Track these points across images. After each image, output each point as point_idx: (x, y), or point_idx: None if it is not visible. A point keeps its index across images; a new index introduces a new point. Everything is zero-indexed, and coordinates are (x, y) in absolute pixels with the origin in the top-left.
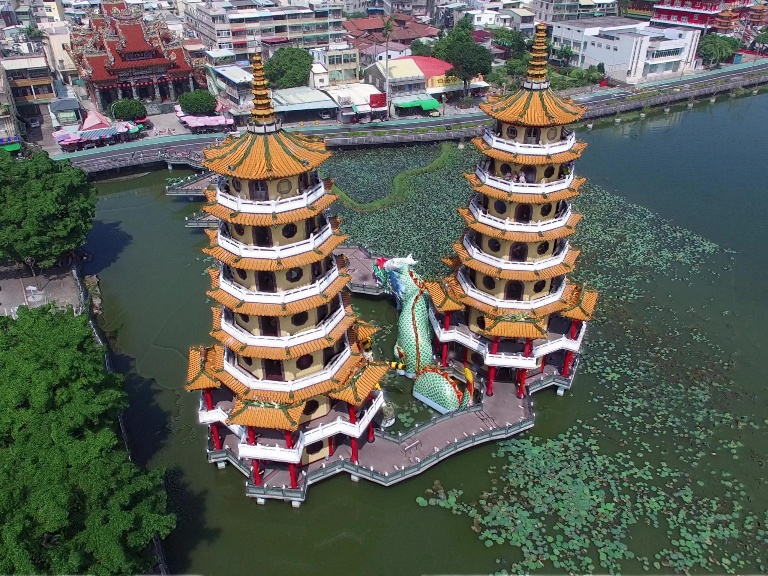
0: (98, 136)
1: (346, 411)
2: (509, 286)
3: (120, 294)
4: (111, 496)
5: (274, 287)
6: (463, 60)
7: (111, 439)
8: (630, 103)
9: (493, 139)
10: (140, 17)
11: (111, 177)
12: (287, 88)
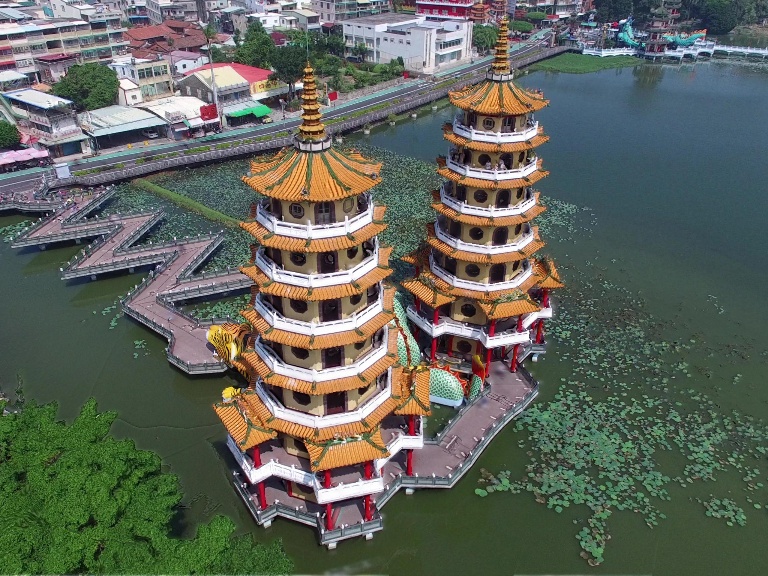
0: None
1: (395, 426)
2: None
3: (9, 374)
4: None
5: (339, 314)
6: (286, 63)
7: (229, 526)
8: (438, 91)
9: (472, 132)
10: None
11: None
12: (96, 109)
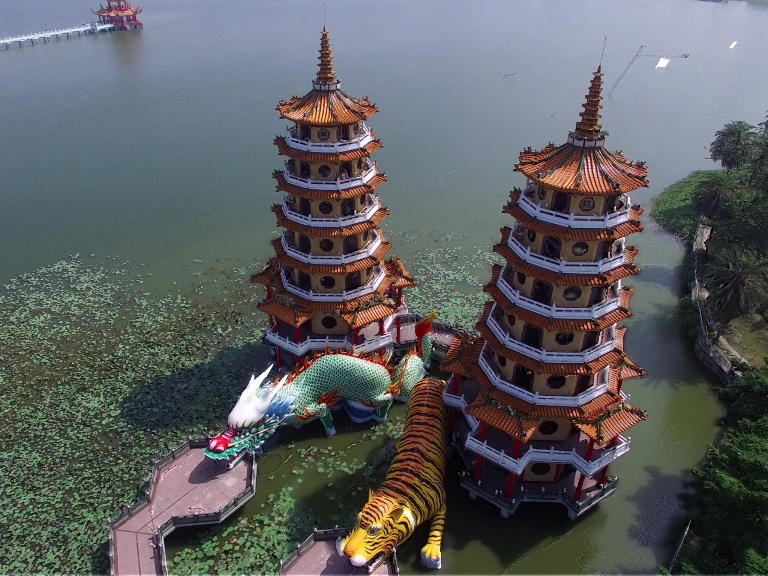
0: None
1: None
2: None
3: None
4: None
5: None
6: None
7: None
8: None
9: None
10: None
11: None
12: None
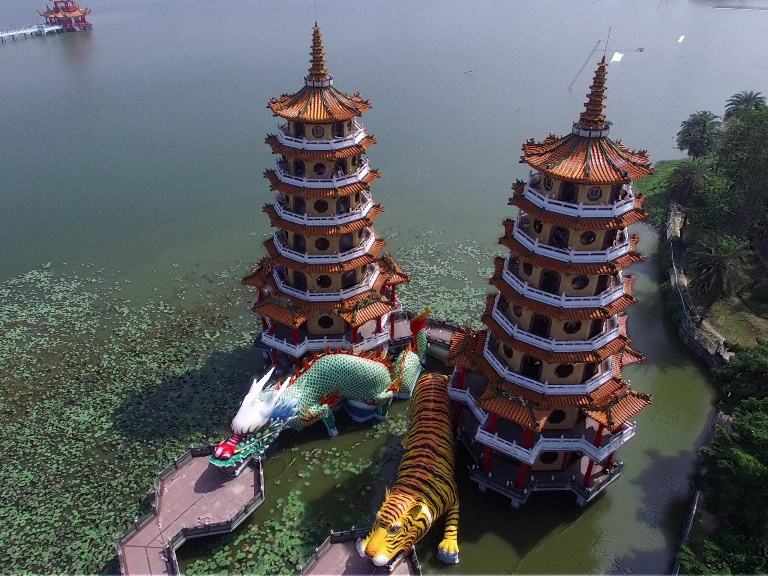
0: None
1: None
2: None
3: None
4: None
5: None
6: None
7: None
8: None
9: None
10: None
11: None
12: None
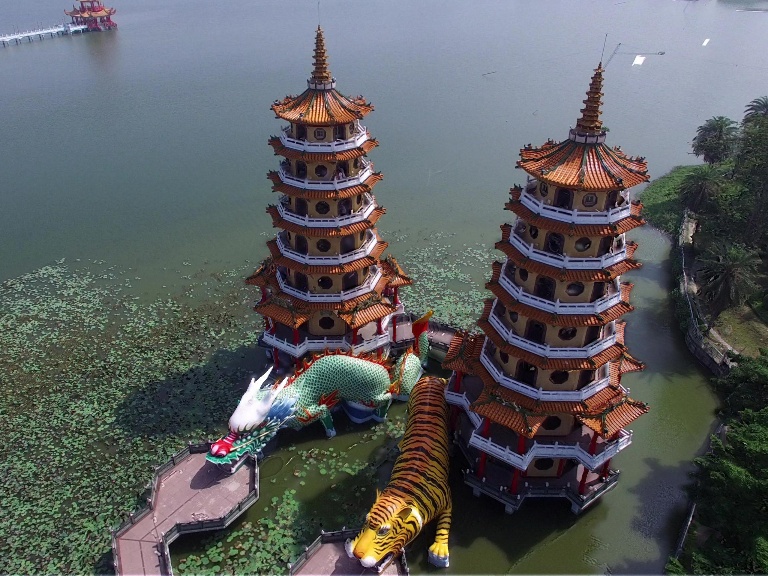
0: None
1: None
2: None
3: None
4: None
5: None
6: None
7: None
8: None
9: None
10: None
11: None
12: None
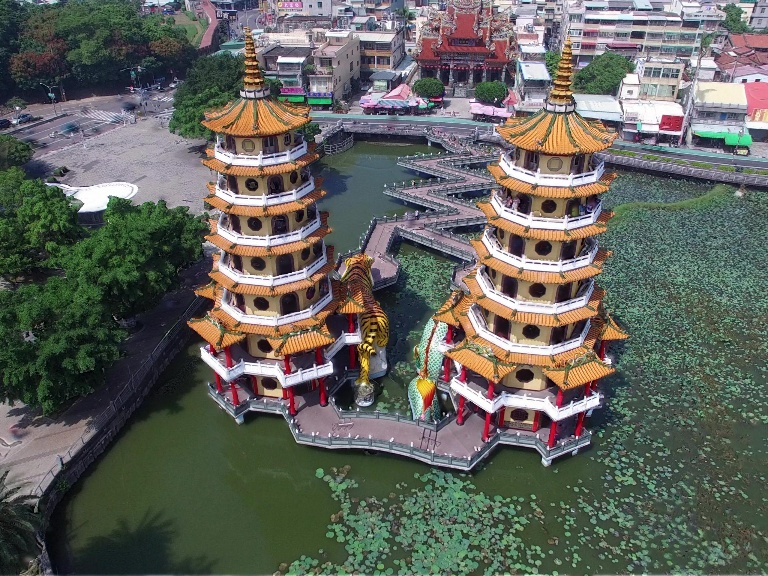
0: (391, 105)
1: (297, 365)
2: (500, 319)
3: None
4: (73, 329)
5: (240, 229)
6: None
7: (98, 295)
8: None
9: None
10: (477, 7)
11: (380, 141)
12: (590, 94)
